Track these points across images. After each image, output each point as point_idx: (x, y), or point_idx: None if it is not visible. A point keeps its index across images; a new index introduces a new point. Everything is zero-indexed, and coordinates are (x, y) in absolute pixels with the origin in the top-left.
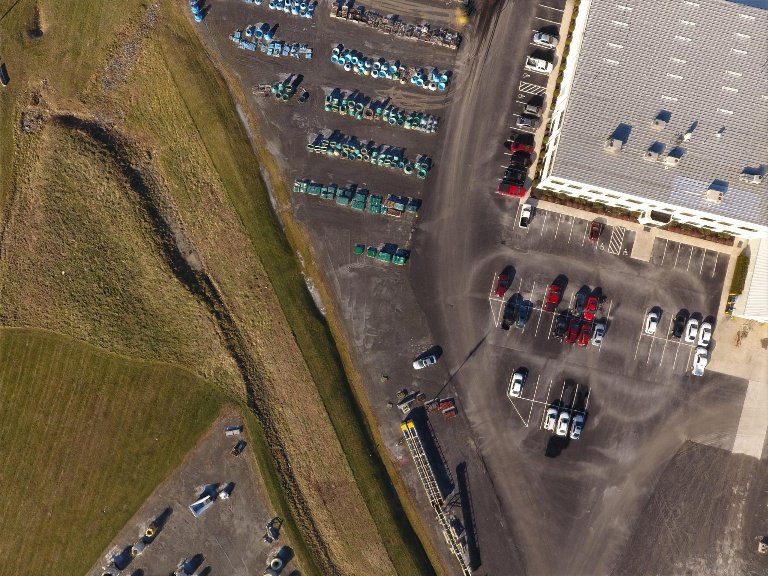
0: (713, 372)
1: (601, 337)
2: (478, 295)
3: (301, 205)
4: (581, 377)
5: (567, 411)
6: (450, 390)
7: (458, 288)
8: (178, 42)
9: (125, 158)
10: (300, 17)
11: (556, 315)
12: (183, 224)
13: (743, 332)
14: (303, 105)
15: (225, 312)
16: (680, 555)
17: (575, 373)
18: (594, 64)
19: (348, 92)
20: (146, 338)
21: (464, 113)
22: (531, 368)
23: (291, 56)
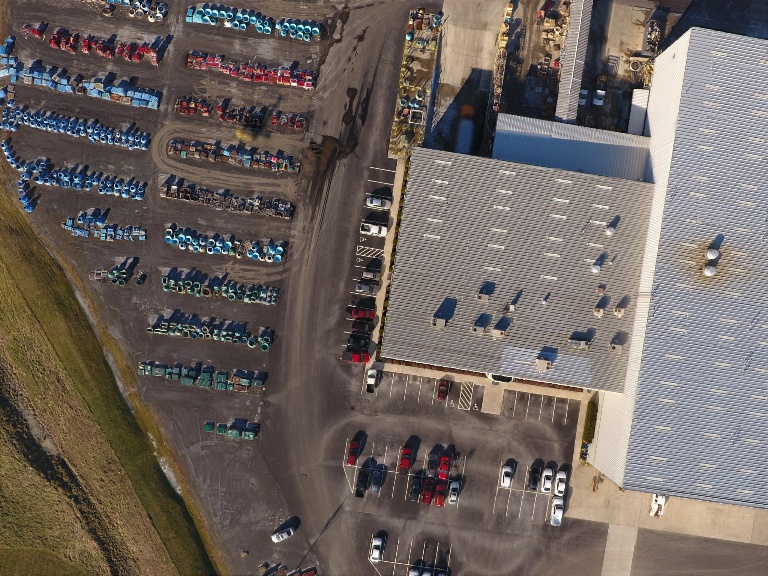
0: (572, 519)
1: (456, 497)
2: (331, 463)
3: (147, 387)
4: (441, 535)
5: (429, 571)
6: (311, 559)
7: (311, 457)
8: (10, 234)
9: None
10: (131, 199)
11: (411, 476)
12: (35, 410)
13: (599, 477)
14: (141, 287)
15: (84, 495)
16: None
17: (435, 532)
18: (415, 241)
19: (185, 270)
20: (9, 525)
21: (303, 282)
22: (390, 531)
23: (125, 239)
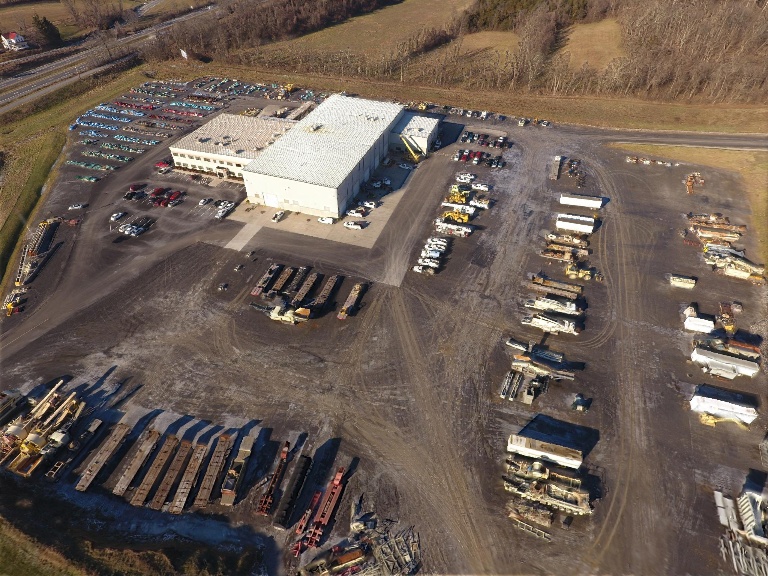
0: (229, 219)
1: (172, 202)
2: (123, 191)
3: None
4: (155, 217)
5: None
6: None
7: None
8: None
9: (4, 158)
10: None
11: None
12: None
13: None
14: None
15: None
16: (165, 288)
17: None
18: None
19: None
20: None
21: None
22: (130, 213)
23: None
